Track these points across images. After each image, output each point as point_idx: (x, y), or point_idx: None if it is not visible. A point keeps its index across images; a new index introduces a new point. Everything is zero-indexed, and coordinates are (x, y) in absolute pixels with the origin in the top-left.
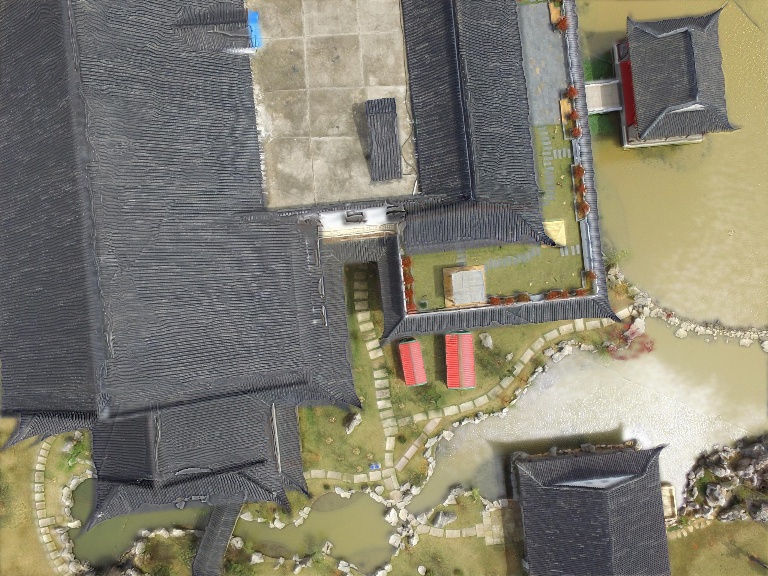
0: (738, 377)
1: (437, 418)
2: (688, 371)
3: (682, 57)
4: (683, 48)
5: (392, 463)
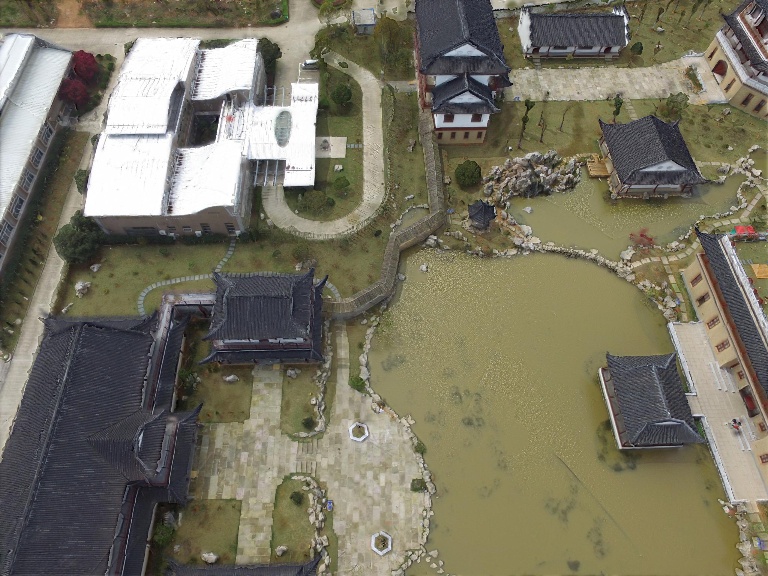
0: (551, 227)
1: (743, 218)
2: (583, 233)
3: (667, 401)
4: (669, 407)
5: (765, 197)
